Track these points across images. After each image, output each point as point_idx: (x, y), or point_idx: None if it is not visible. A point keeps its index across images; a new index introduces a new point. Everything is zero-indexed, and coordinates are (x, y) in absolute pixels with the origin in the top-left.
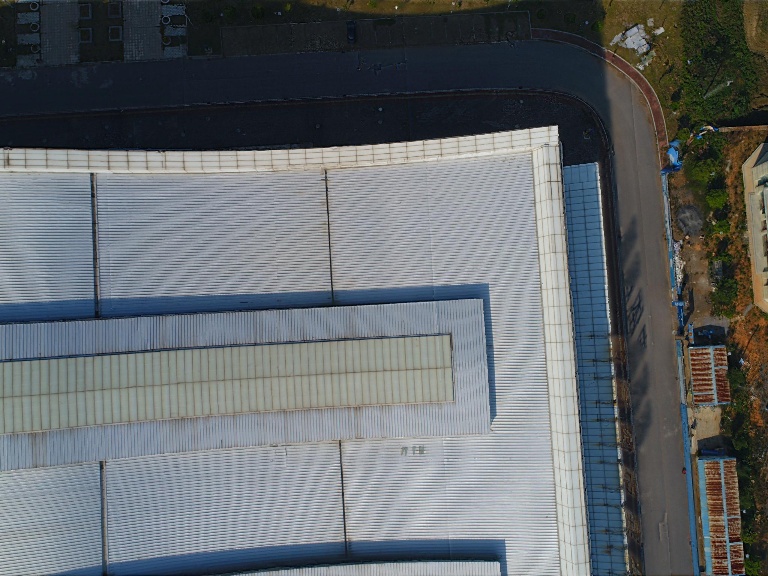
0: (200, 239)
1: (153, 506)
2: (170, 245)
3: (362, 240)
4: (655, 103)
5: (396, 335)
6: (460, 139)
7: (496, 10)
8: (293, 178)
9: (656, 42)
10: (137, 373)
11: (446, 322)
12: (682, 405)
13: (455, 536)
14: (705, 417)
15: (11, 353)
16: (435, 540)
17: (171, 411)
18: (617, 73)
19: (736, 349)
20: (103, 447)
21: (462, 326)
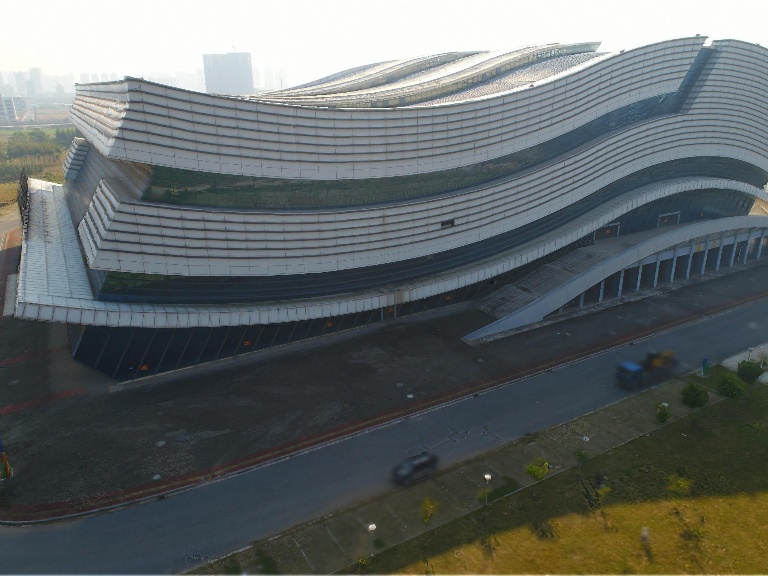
0: None
1: None
2: None
3: None
4: None
5: None
6: None
7: None
8: None
9: None
10: None
11: None
12: None
13: None
14: None
15: None
16: None
17: None
18: None
19: None
20: None
21: None
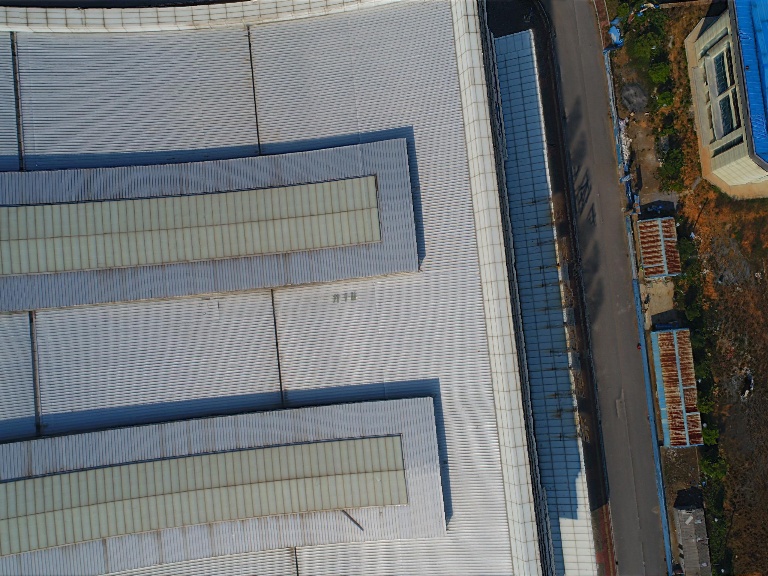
0: (124, 97)
1: (85, 359)
2: (94, 103)
3: (287, 93)
4: None
5: (322, 180)
6: None
7: None
8: (216, 35)
9: None
10: (62, 224)
11: (370, 164)
12: (634, 280)
13: (390, 379)
14: (658, 292)
15: None
16: (370, 384)
17: (98, 261)
18: None
19: (686, 223)
20: (30, 296)
21: (386, 166)
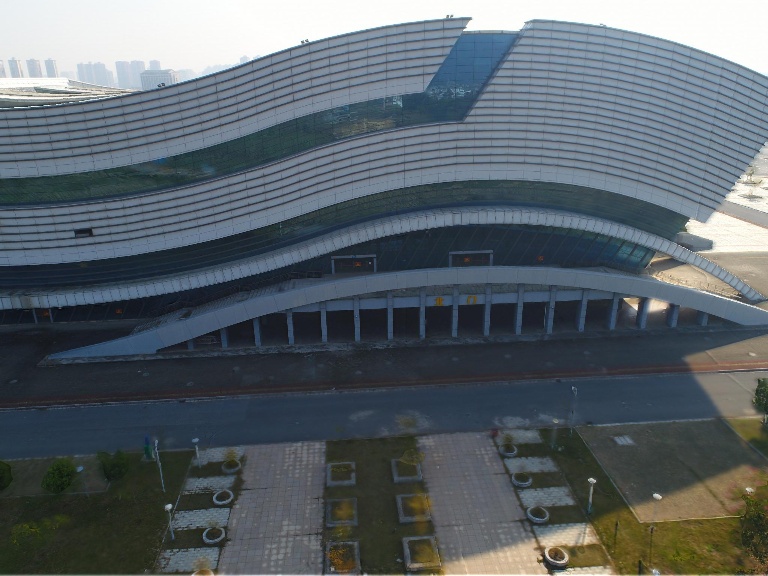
0: None
1: None
2: None
3: None
4: None
5: None
6: None
7: None
8: None
9: None
10: None
11: None
12: None
13: None
14: None
15: None
16: None
17: None
18: None
19: None
20: None
21: None
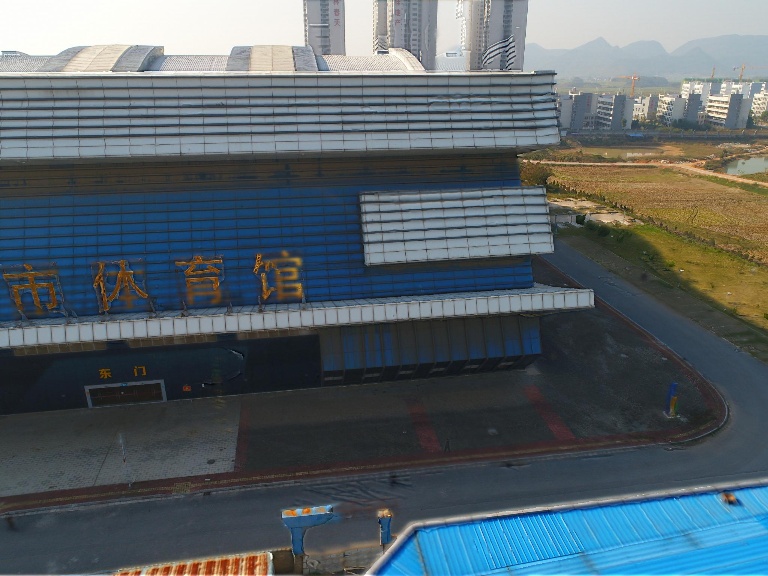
0: None
1: None
2: None
3: None
4: None
5: None
6: None
7: None
8: None
9: None
10: None
11: None
12: None
13: None
14: None
15: None
16: None
17: None
18: None
19: None
20: None
21: None
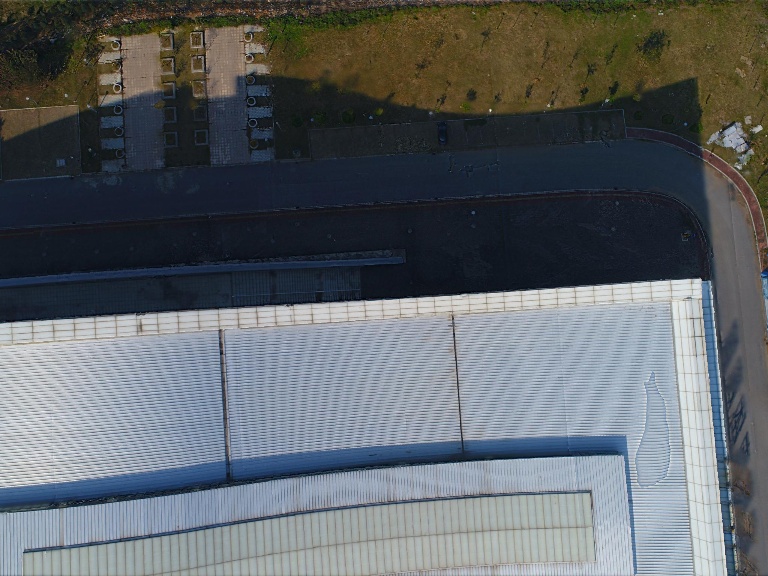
0: (328, 391)
1: None
2: (298, 399)
3: (492, 388)
4: (754, 203)
5: (533, 491)
6: (596, 288)
7: (590, 109)
8: (420, 325)
9: (754, 140)
10: (273, 539)
11: (585, 479)
12: None
13: None
14: None
15: (150, 528)
16: None
17: None
18: (714, 172)
19: None
20: None
21: (602, 483)
